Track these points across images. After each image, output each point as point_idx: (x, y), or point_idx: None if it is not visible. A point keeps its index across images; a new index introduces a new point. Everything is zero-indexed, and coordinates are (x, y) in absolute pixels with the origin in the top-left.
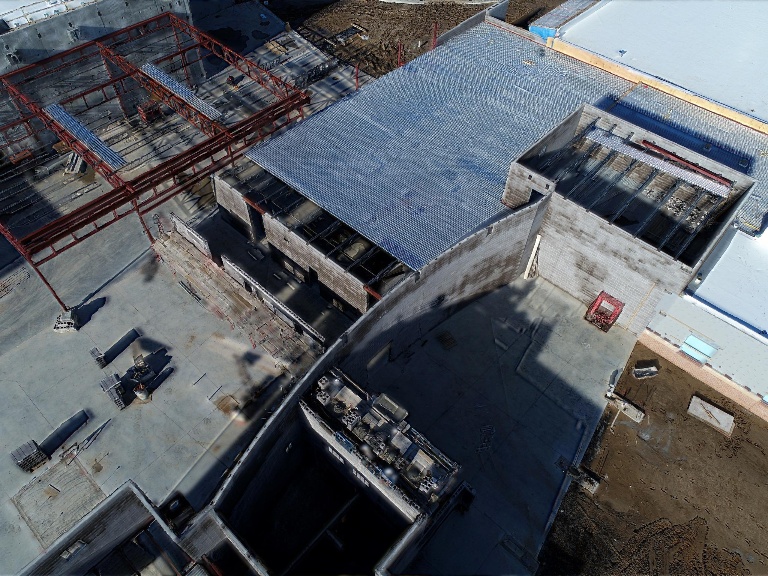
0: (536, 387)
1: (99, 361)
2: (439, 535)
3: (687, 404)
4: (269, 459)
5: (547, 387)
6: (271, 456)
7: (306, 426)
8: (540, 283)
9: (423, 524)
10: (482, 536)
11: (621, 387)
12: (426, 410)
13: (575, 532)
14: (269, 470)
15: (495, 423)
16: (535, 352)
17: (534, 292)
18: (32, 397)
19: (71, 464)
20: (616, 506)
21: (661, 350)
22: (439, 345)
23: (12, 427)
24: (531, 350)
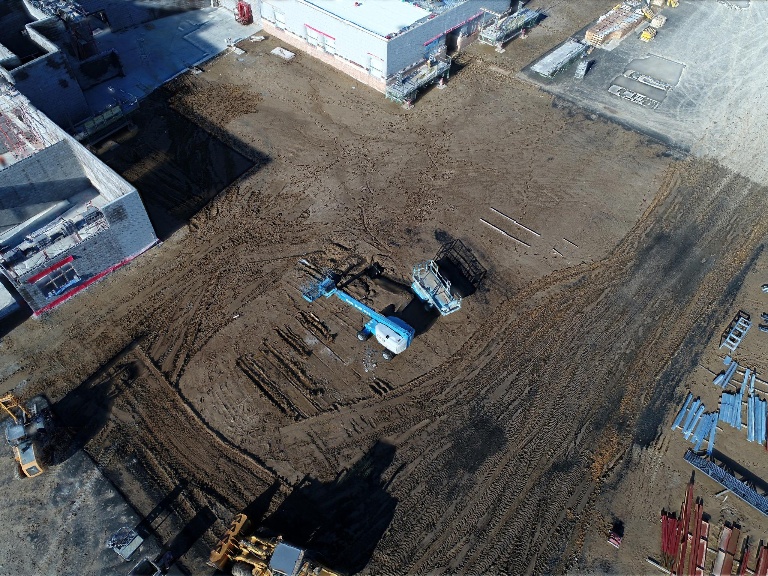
0: (190, 42)
1: None
2: (105, 83)
3: None
4: (5, 23)
5: (197, 42)
6: (7, 23)
7: (31, 18)
8: (220, 9)
9: (63, 29)
10: (128, 84)
11: (240, 44)
12: (123, 48)
13: (179, 85)
14: (8, 34)
15: (159, 53)
16: (199, 32)
17: (214, 12)
18: None
19: None
20: (207, 79)
21: (271, 31)
22: (144, 28)
23: None
24: (197, 31)
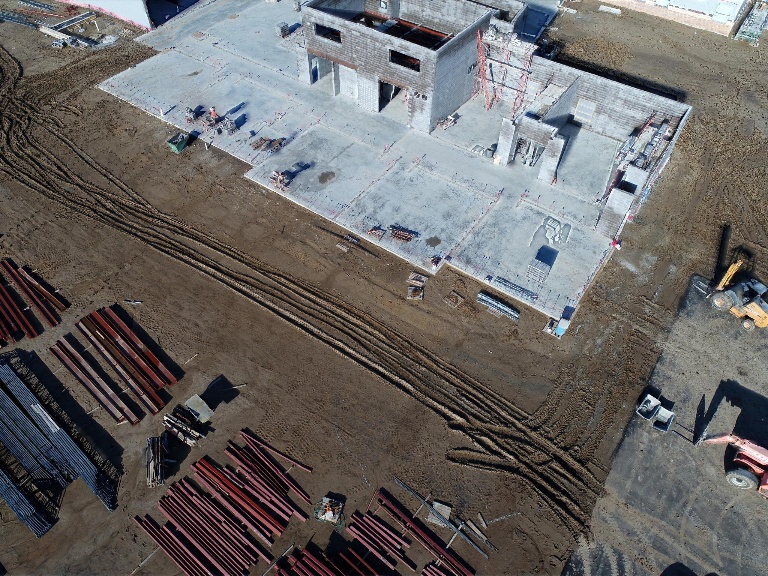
0: None
1: (299, 5)
2: None
3: (598, 8)
4: None
5: None
6: None
7: None
8: None
9: None
10: None
11: (565, 5)
12: None
13: (549, 41)
14: None
15: None
16: None
17: None
18: (268, 21)
19: (302, 36)
20: (567, 34)
21: None
22: None
23: (265, 29)
24: None
